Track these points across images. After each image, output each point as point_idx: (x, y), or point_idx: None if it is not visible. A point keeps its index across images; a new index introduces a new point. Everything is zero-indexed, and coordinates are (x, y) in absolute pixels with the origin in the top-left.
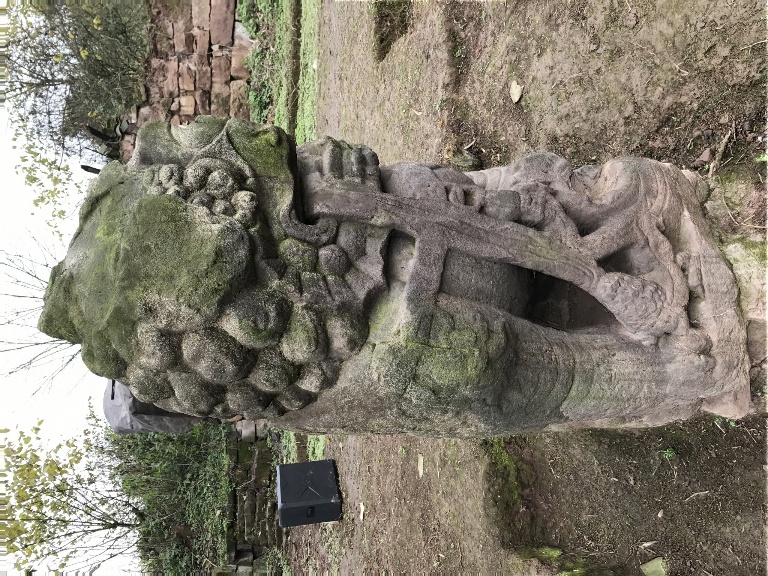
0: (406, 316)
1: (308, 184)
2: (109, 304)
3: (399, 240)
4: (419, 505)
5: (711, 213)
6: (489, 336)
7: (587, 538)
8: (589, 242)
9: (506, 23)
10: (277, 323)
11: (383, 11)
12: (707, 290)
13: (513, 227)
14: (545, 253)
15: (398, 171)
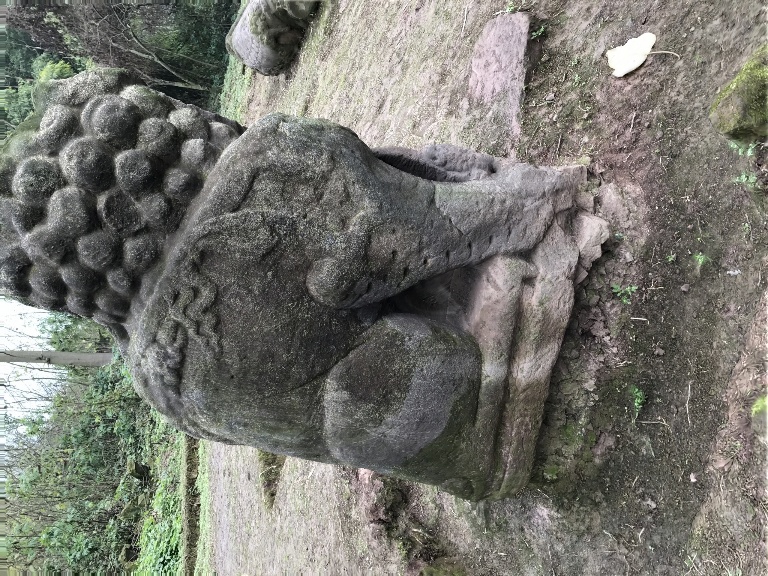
0: None
1: None
2: None
3: None
4: None
5: None
6: None
7: None
8: None
9: None
10: (165, 96)
11: (270, 477)
12: None
13: None
14: None
15: None
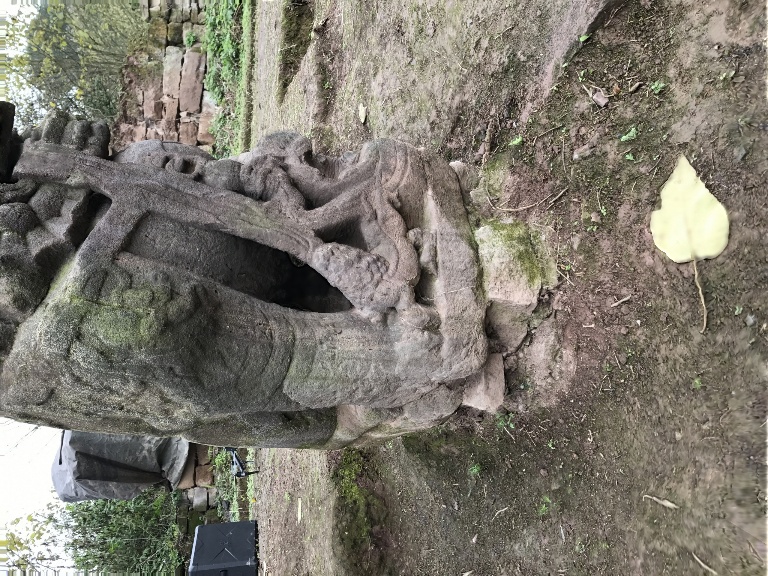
0: (75, 272)
1: (22, 151)
2: None
3: (105, 205)
4: (295, 554)
5: (474, 200)
6: (172, 298)
7: (424, 575)
8: (310, 213)
9: (356, 50)
10: None
11: (288, 59)
12: (441, 267)
13: (229, 196)
14: (258, 221)
15: (131, 145)
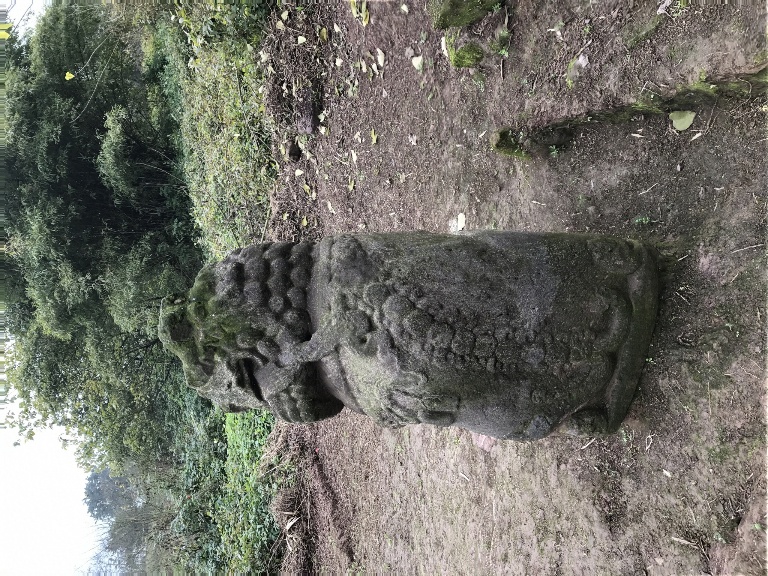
0: None
1: None
2: None
3: None
4: None
5: None
6: None
7: None
8: None
9: None
10: None
11: None
12: None
13: None
14: None
15: None
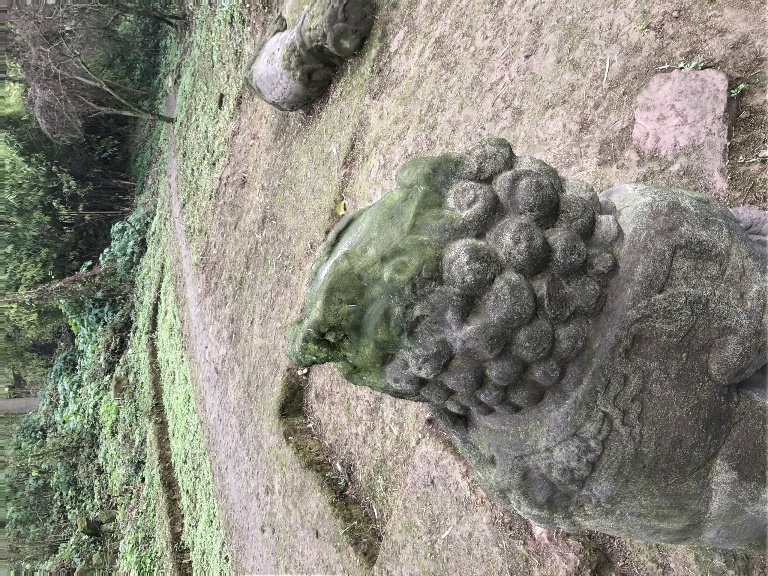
0: None
1: None
2: (409, 208)
3: None
4: None
5: None
6: None
7: None
8: None
9: None
10: None
11: (354, 534)
12: None
13: None
14: None
15: None
